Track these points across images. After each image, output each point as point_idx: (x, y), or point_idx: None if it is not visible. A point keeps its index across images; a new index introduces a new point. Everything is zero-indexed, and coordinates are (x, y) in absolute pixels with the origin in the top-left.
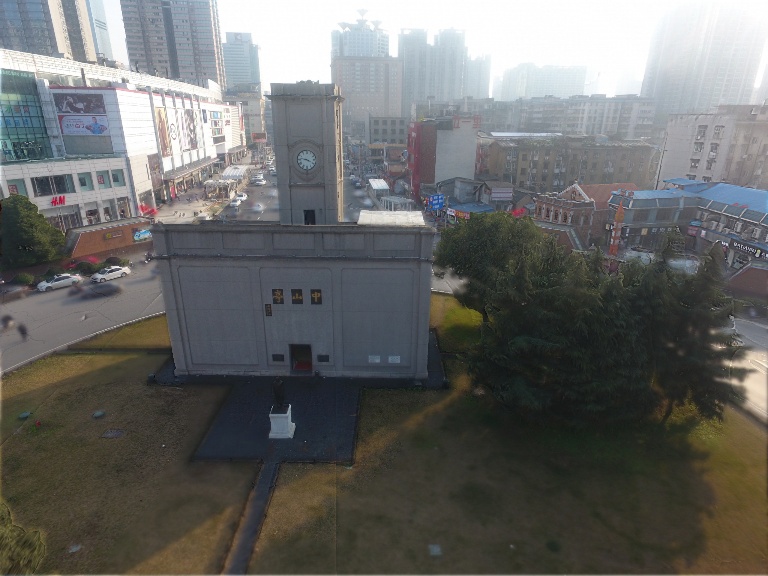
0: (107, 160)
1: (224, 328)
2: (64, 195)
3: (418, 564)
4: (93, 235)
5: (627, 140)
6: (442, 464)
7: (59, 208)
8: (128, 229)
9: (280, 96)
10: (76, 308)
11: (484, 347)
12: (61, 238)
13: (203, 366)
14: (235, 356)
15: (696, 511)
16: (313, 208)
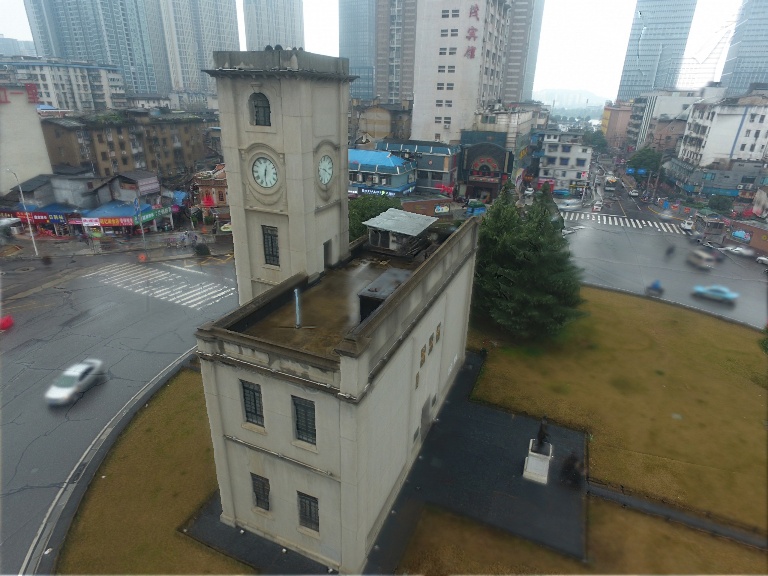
0: None
1: (391, 445)
2: None
3: (692, 426)
4: None
5: (175, 113)
6: (589, 387)
7: None
8: None
9: (311, 73)
10: None
11: (529, 299)
12: None
13: (375, 527)
14: (394, 474)
15: (621, 324)
16: (330, 237)
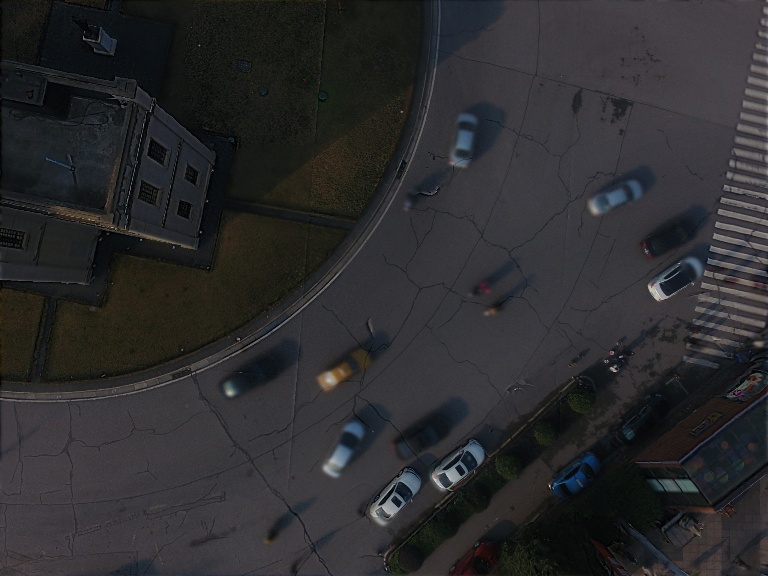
0: None
1: None
2: None
3: None
4: None
5: None
6: None
7: None
8: None
9: None
10: (393, 361)
11: None
12: None
13: None
14: None
15: None
16: None
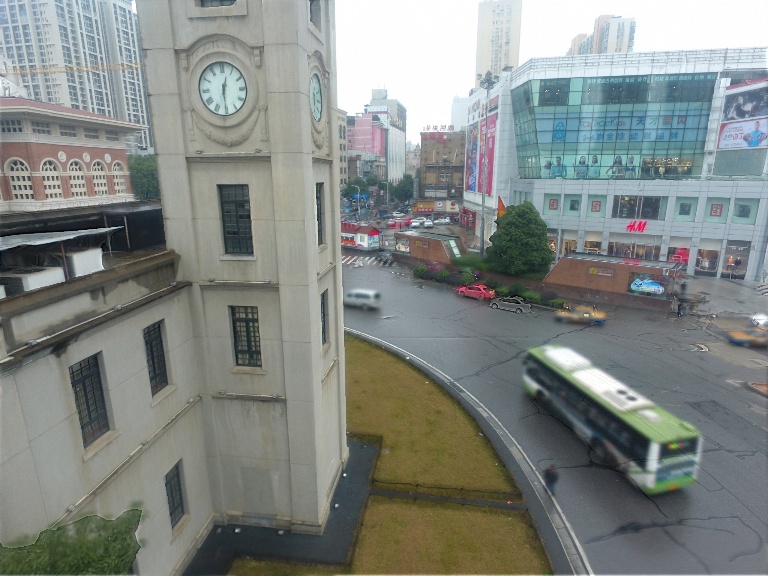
0: (735, 183)
1: None
2: (647, 221)
3: None
4: (575, 264)
5: None
6: None
7: (636, 235)
8: (625, 271)
9: None
10: (412, 310)
11: None
12: (541, 256)
13: None
14: None
15: None
16: None
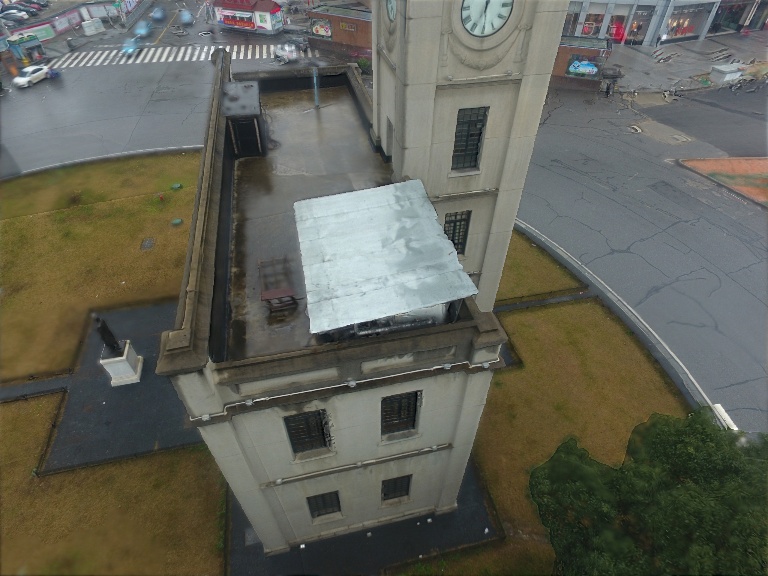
0: None
1: None
2: None
3: None
4: None
5: None
6: None
7: None
8: (566, 53)
9: None
10: None
11: None
12: None
13: None
14: None
15: None
16: (392, 120)
